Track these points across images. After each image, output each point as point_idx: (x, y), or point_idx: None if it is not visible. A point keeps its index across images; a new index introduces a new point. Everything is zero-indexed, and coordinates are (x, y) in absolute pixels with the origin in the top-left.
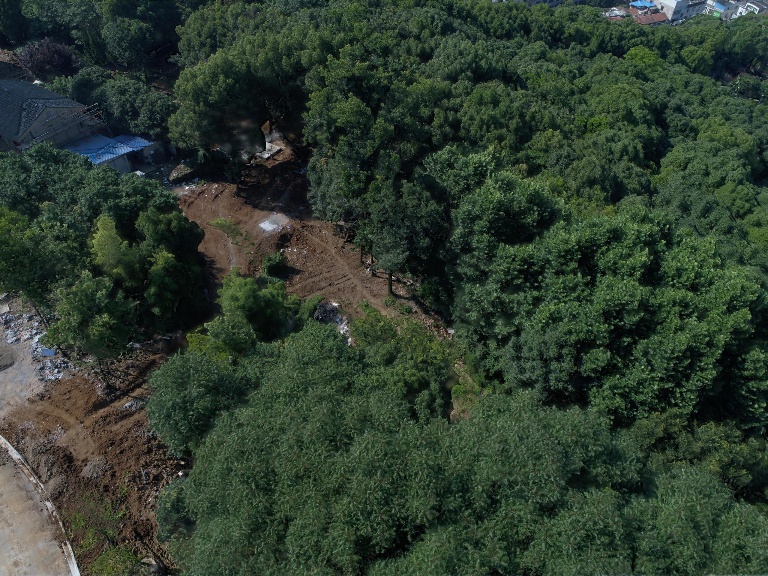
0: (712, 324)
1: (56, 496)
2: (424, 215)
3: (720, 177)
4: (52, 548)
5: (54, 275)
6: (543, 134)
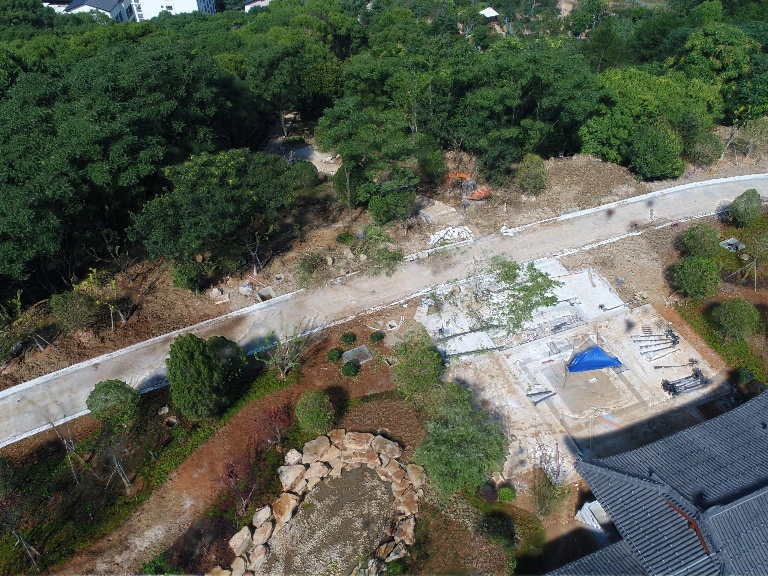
0: None
1: None
2: None
3: None
4: None
5: None
6: None
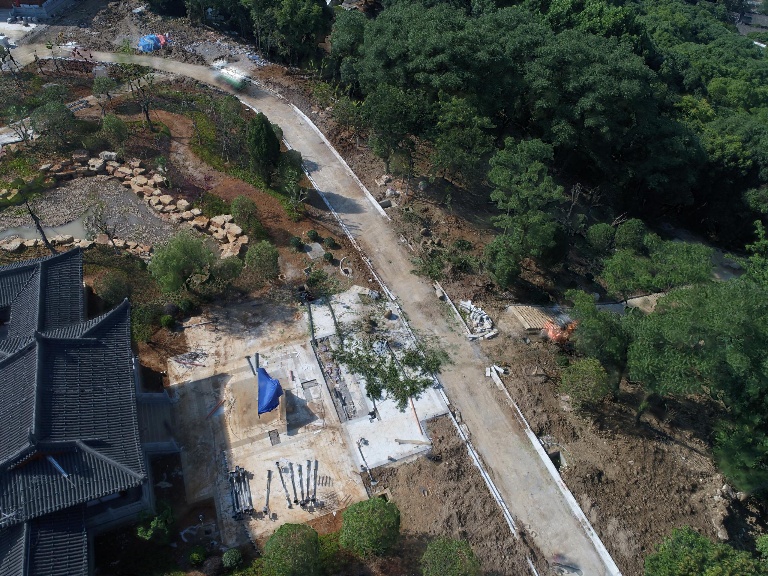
0: None
1: (280, 93)
2: None
3: (652, 28)
4: (284, 106)
5: None
6: None
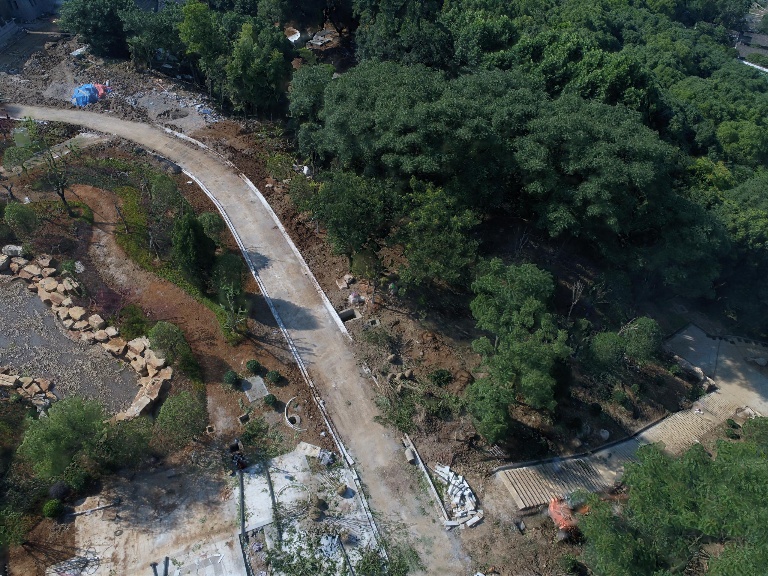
0: (605, 74)
1: (231, 159)
2: (437, 39)
3: (653, 62)
4: (234, 176)
5: (221, 49)
6: (519, 17)
